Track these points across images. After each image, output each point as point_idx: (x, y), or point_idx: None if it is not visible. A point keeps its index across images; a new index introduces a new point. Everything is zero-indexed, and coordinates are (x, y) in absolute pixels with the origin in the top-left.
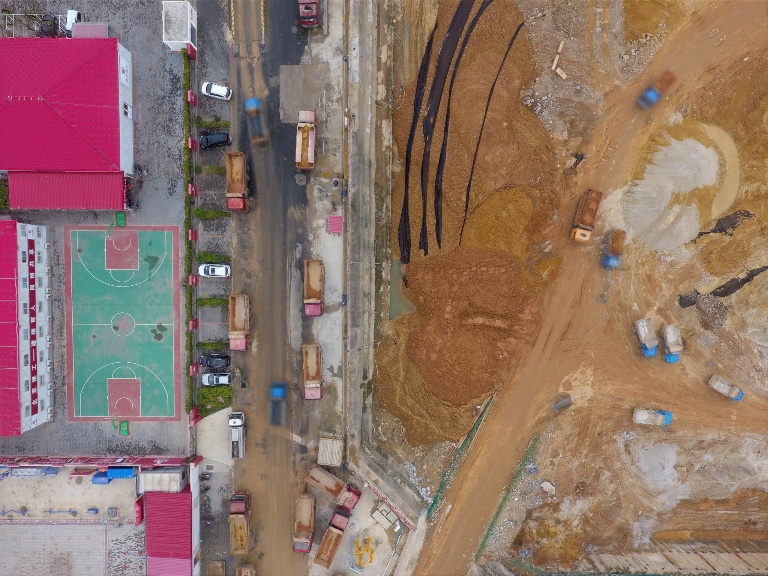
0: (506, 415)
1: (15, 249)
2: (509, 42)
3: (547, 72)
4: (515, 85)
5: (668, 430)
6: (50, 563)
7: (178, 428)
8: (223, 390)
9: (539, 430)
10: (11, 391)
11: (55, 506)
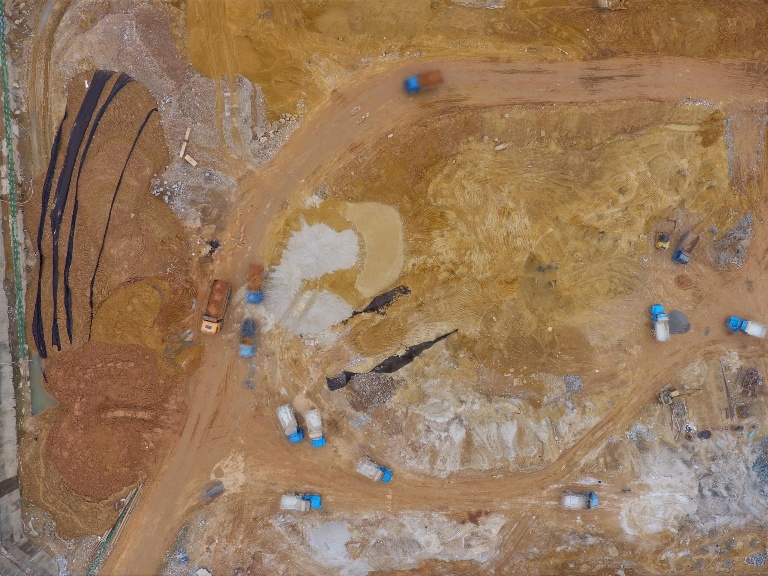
0: (153, 506)
1: None
2: (138, 129)
3: (177, 159)
4: (146, 173)
5: (323, 512)
6: None
7: None
8: None
9: (190, 519)
10: None
11: None
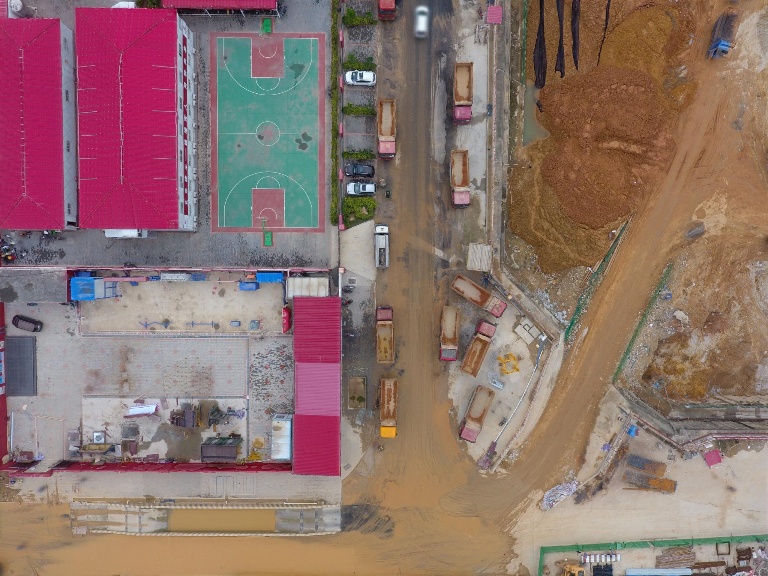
0: (641, 241)
1: (175, 37)
2: None
3: None
4: None
5: None
6: (192, 377)
7: (322, 239)
8: (368, 200)
9: (673, 257)
10: (170, 182)
11: (197, 319)
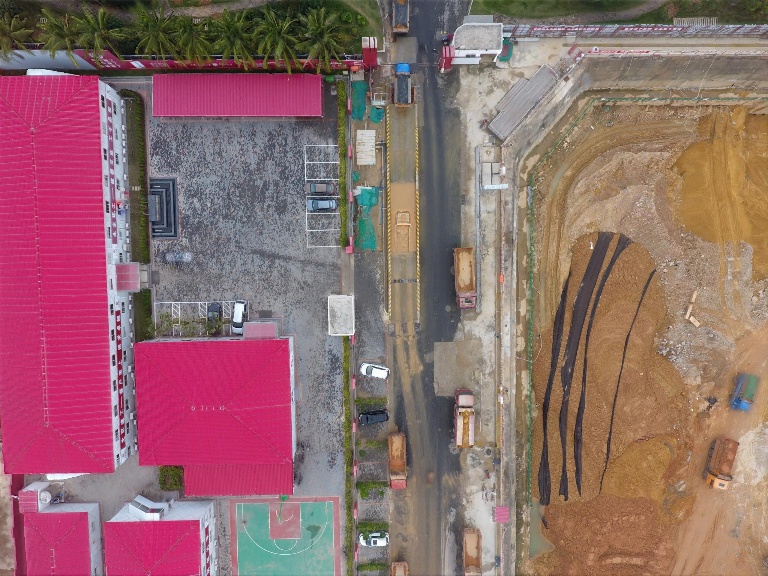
0: None
1: (199, 547)
2: (642, 290)
3: (680, 320)
4: (649, 332)
5: None
6: None
7: None
8: None
9: None
10: None
11: None
